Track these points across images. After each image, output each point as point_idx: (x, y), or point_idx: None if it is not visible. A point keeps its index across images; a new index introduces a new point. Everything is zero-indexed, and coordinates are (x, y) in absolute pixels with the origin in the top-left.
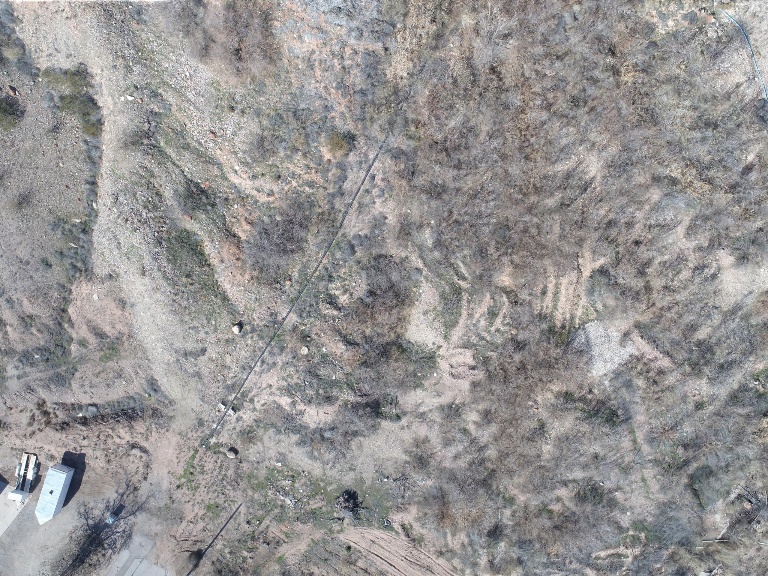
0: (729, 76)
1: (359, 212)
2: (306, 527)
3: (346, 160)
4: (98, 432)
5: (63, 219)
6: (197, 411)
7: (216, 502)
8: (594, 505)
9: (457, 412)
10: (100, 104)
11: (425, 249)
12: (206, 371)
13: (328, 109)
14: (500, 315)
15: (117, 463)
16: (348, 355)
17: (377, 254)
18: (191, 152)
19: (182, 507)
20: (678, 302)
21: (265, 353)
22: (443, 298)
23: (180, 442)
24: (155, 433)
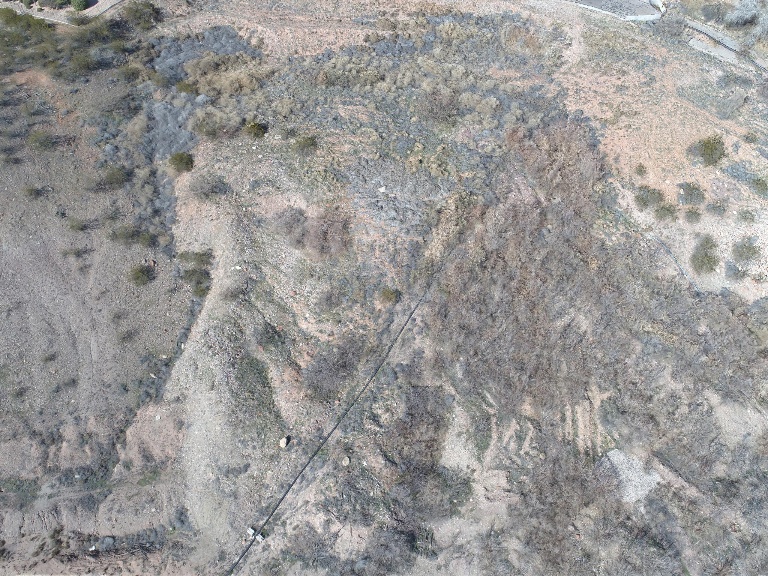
0: (665, 271)
1: (402, 345)
2: None
3: (394, 308)
4: (107, 565)
5: (153, 355)
6: (221, 542)
7: None
8: None
9: (497, 539)
10: (213, 276)
11: (456, 379)
12: (244, 490)
13: (382, 275)
14: (527, 438)
15: None
16: (386, 472)
17: (415, 385)
18: (274, 304)
19: None
20: (685, 435)
21: (306, 468)
22: (474, 420)
23: None
24: (170, 566)
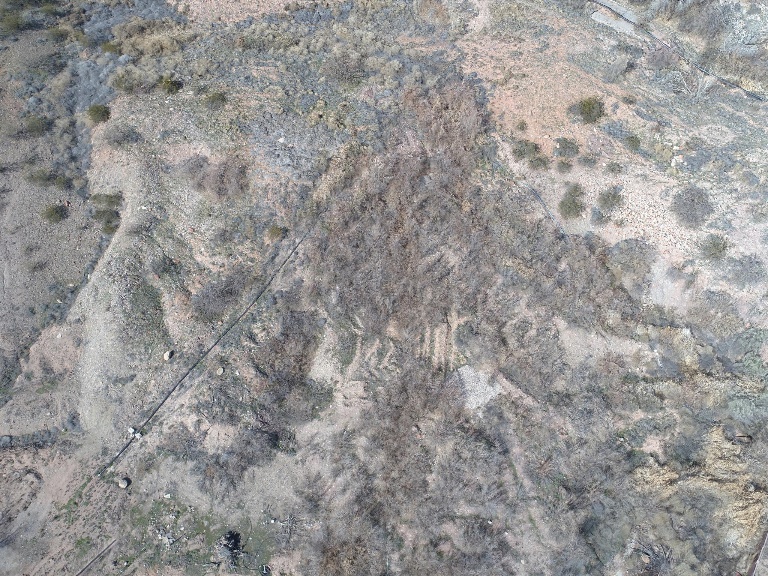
0: (533, 214)
1: (284, 275)
2: (177, 572)
3: (280, 243)
4: (1, 457)
5: (61, 283)
6: (106, 440)
7: (89, 537)
8: (484, 546)
9: (347, 437)
10: (122, 216)
11: (330, 305)
12: (128, 396)
13: (273, 214)
14: (387, 355)
15: (4, 490)
16: (257, 382)
17: (294, 310)
18: (173, 240)
19: (50, 541)
20: (531, 354)
21: (186, 378)
22: (341, 340)
23: (77, 470)
24: (57, 459)
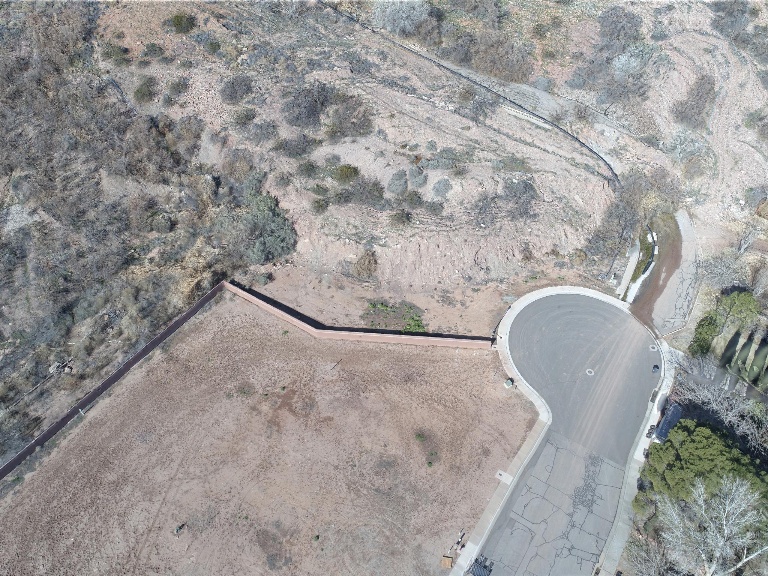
0: (109, 99)
1: None
2: None
3: None
4: None
5: None
6: None
7: None
8: None
9: None
10: None
11: None
12: None
13: None
14: None
15: None
16: None
17: None
18: None
19: None
20: (73, 195)
21: None
22: None
23: None
24: None
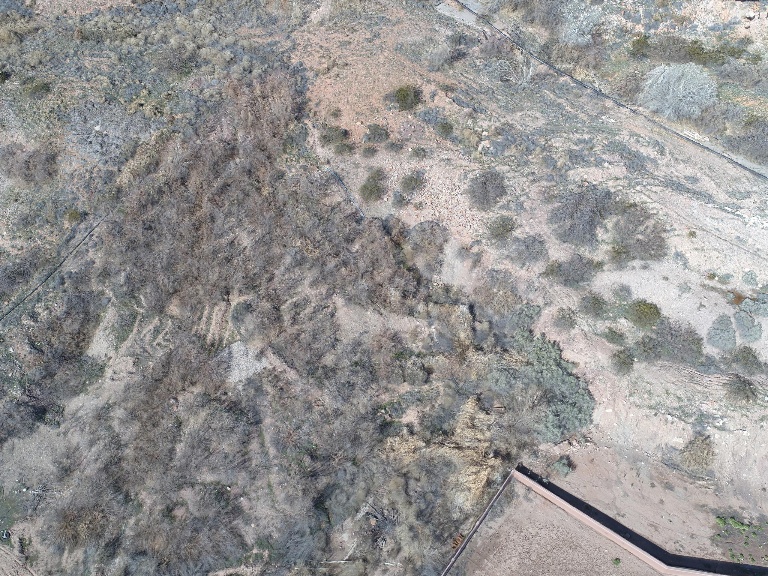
0: (332, 198)
1: (75, 256)
2: None
3: (77, 227)
4: None
5: None
6: None
7: None
8: (217, 510)
9: (107, 410)
10: None
11: (117, 285)
12: None
13: (75, 199)
14: (163, 332)
15: None
16: (30, 358)
17: (83, 290)
18: None
19: None
20: (304, 331)
21: None
22: (121, 318)
23: None
24: None
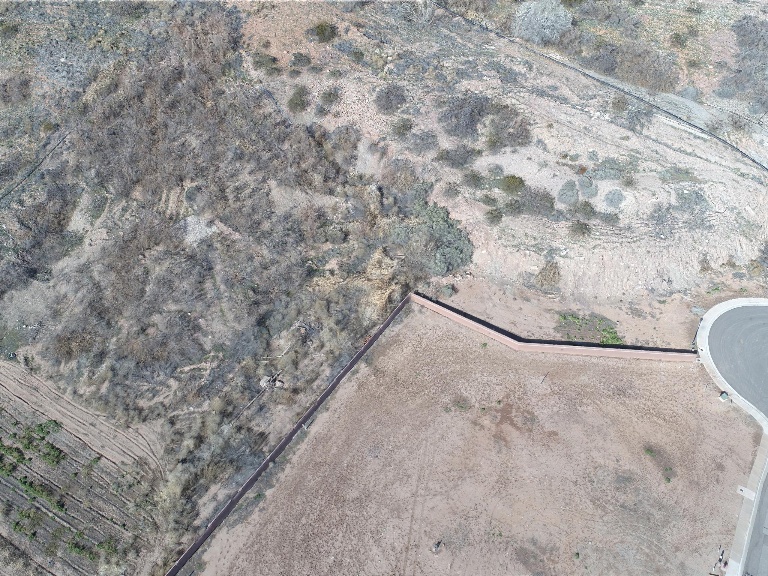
0: (265, 109)
1: (52, 157)
2: None
3: (52, 135)
4: None
5: None
6: None
7: None
8: (181, 328)
9: (88, 265)
10: None
11: (89, 178)
12: None
13: (48, 115)
14: (129, 210)
15: None
16: (21, 233)
17: None
18: None
19: None
20: (245, 206)
21: None
22: (94, 201)
23: None
24: None
